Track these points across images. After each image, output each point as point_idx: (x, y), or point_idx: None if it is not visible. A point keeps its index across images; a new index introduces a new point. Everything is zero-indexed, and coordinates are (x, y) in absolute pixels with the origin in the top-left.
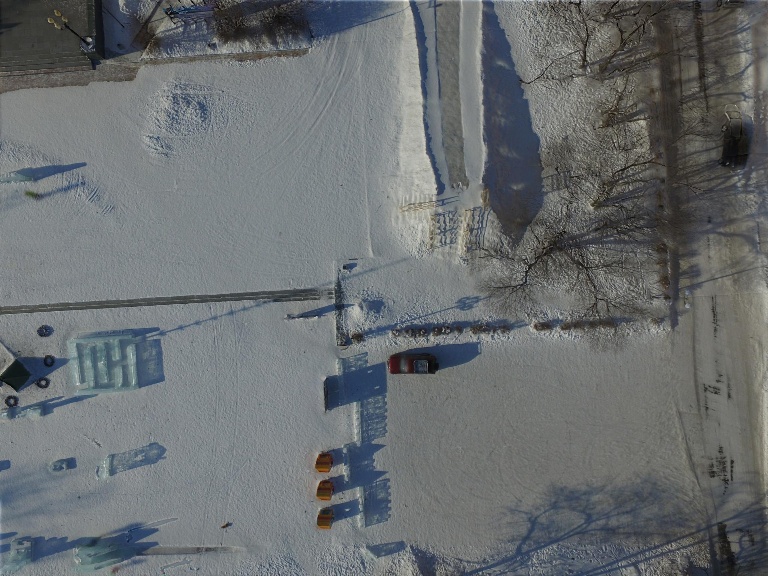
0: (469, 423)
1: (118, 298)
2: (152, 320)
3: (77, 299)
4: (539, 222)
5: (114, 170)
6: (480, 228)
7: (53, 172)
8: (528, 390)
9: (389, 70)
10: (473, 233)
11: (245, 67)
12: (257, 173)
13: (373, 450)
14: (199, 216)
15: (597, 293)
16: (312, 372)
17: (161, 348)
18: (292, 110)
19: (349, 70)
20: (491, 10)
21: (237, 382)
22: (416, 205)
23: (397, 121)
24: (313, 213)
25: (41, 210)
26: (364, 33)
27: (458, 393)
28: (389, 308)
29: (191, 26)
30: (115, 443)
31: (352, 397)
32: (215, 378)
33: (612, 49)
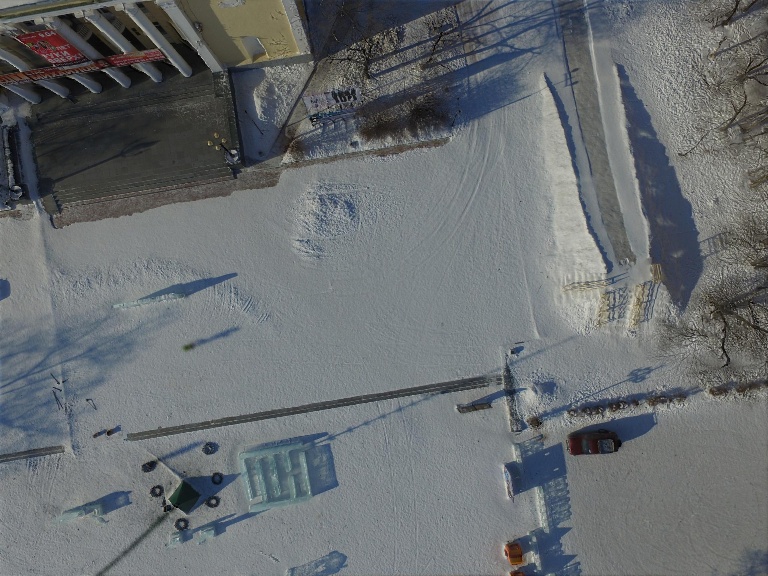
0: (653, 496)
1: (283, 407)
2: (319, 425)
3: (241, 412)
4: (702, 287)
5: (266, 277)
6: (649, 301)
7: (204, 286)
8: (709, 455)
9: (533, 151)
10: (642, 306)
11: (388, 162)
12: (412, 266)
13: (559, 534)
14: (358, 315)
15: (767, 351)
16: (488, 461)
17: (331, 453)
18: (440, 200)
19: (492, 154)
20: (627, 82)
21: (413, 479)
22: (581, 284)
23: (548, 201)
24: (473, 300)
25: (195, 325)
26: (503, 116)
27: (639, 466)
28: (561, 388)
29: (329, 126)
30: (293, 556)
31: (532, 482)
32: (390, 478)
33: (749, 109)
